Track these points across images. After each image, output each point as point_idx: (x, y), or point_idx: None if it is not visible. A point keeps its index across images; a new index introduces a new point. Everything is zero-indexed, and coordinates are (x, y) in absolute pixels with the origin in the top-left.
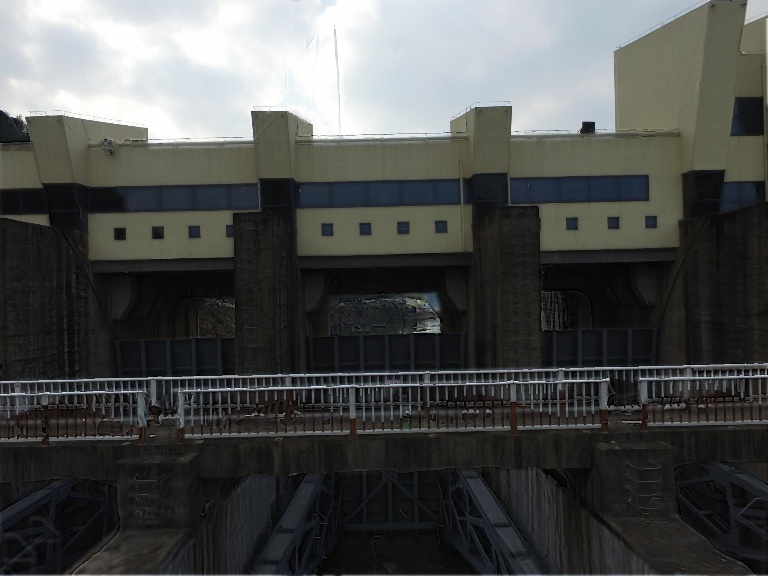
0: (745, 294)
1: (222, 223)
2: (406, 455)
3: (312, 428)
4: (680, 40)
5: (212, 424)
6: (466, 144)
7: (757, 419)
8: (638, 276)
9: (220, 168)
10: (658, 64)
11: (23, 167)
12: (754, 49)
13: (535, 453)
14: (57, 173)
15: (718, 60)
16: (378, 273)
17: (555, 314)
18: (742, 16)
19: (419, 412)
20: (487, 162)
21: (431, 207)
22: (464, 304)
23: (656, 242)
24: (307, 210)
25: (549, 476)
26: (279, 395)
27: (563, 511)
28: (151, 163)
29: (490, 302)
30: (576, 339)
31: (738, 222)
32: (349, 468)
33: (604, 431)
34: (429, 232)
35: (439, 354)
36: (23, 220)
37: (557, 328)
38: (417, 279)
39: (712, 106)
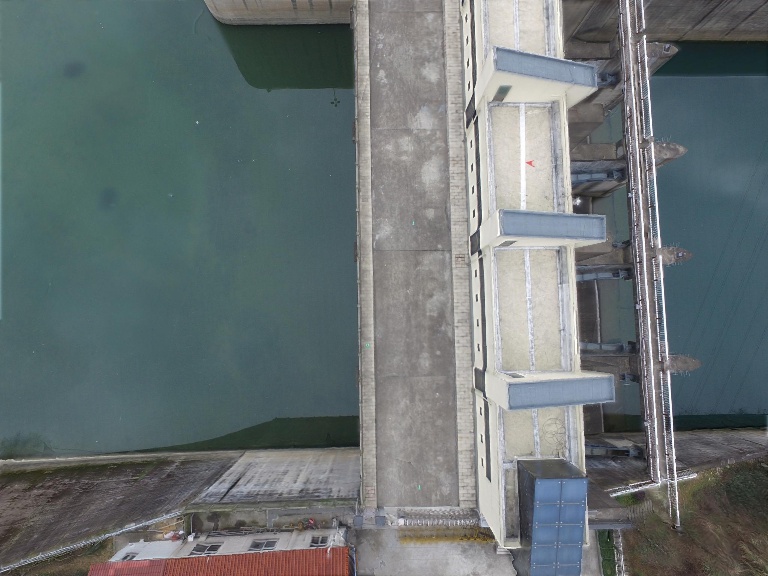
0: None
1: None
2: None
3: None
4: None
5: None
6: None
7: None
8: None
9: None
10: None
11: None
12: None
13: None
14: None
15: None
16: None
17: None
18: None
19: None
20: None
21: None
22: None
23: None
24: None
25: (600, 60)
26: None
27: None
28: None
29: None
30: None
31: None
32: None
33: None
34: None
35: None
36: None
37: None
38: None
39: None
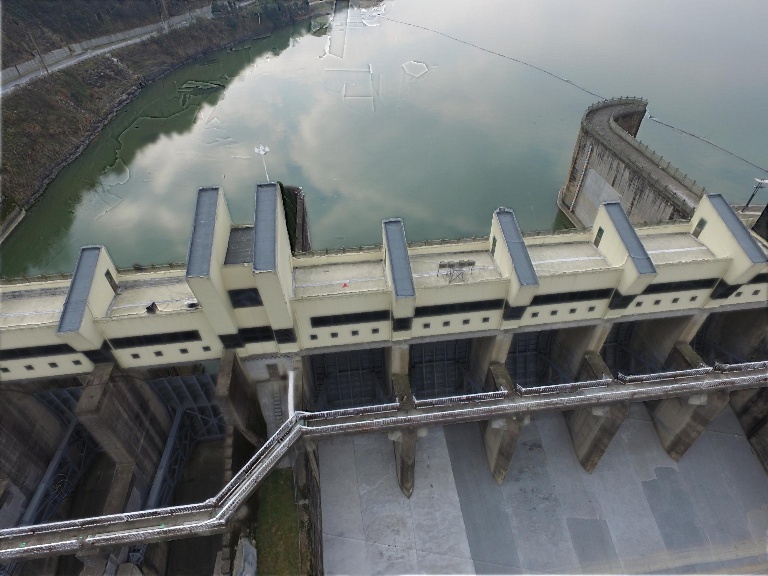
0: None
1: None
2: None
3: None
4: None
5: None
6: None
7: None
8: None
9: None
10: None
11: None
12: None
13: None
14: None
15: None
16: None
17: None
18: (212, 283)
19: None
20: None
21: (65, 355)
22: None
23: (212, 357)
24: None
25: None
26: None
27: None
28: None
29: None
30: None
31: None
32: None
33: (80, 548)
34: (71, 365)
35: None
36: None
37: None
38: None
39: (215, 314)
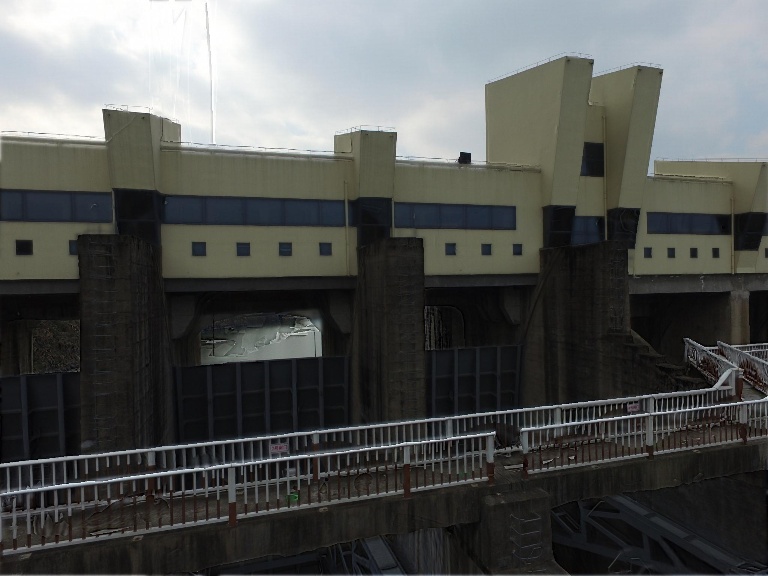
0: (592, 320)
1: (63, 238)
2: (294, 536)
3: (181, 520)
4: (542, 86)
5: (44, 532)
6: (351, 165)
7: (614, 457)
8: (506, 297)
9: (61, 171)
10: (523, 104)
11: None
12: (597, 101)
13: (427, 515)
14: None
15: (572, 109)
16: (257, 292)
17: (431, 325)
18: (590, 73)
19: (309, 486)
20: (372, 186)
21: (315, 228)
22: (348, 326)
23: (521, 268)
24: (174, 226)
25: None
26: (138, 485)
27: (450, 557)
28: None
29: (375, 331)
30: (453, 358)
31: (587, 256)
32: (227, 560)
33: (491, 484)
34: (313, 254)
35: (322, 379)
36: None
37: (433, 338)
38: (299, 298)
39: (567, 149)
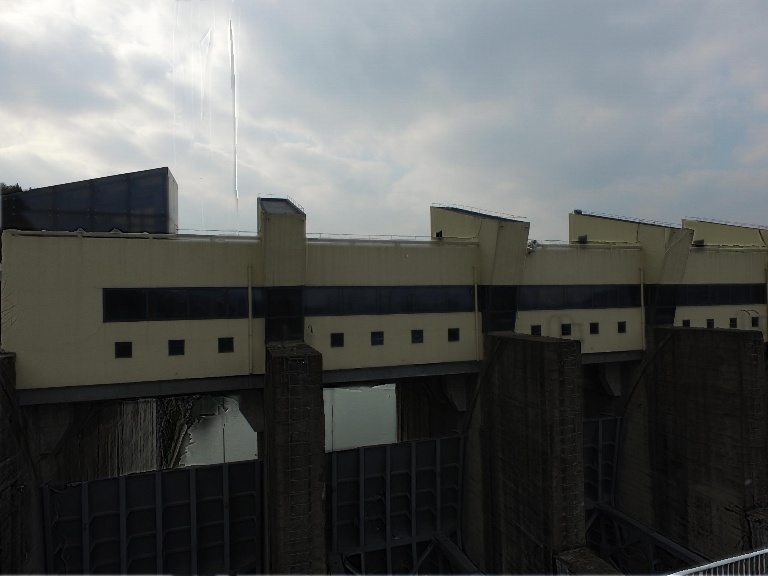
0: None
1: (614, 320)
2: None
3: None
4: None
5: None
6: None
7: None
8: None
9: (612, 270)
10: None
11: (449, 263)
12: None
13: None
14: (508, 276)
15: None
16: None
17: None
18: None
19: None
20: None
21: (749, 306)
22: None
23: None
24: None
25: None
26: None
27: None
28: (559, 263)
29: None
30: None
31: None
32: None
33: None
34: (748, 326)
35: None
36: (450, 318)
37: None
38: None
39: None
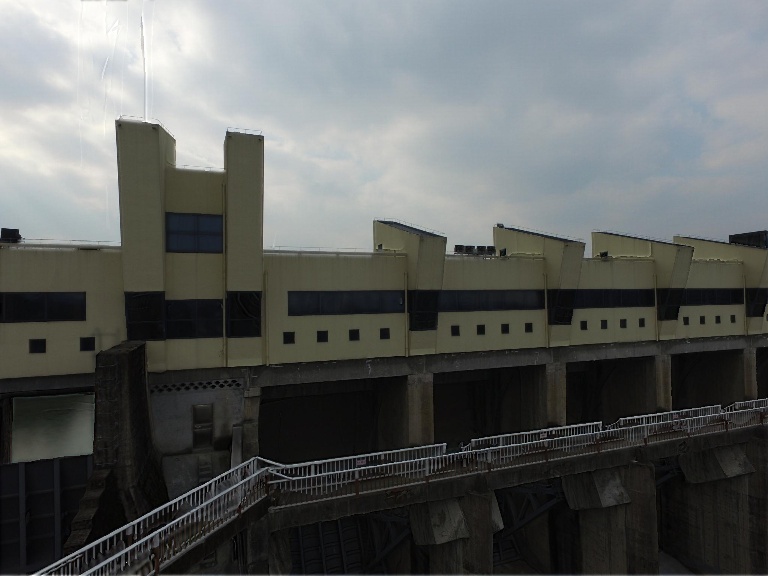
0: None
1: None
2: None
3: None
4: None
5: None
6: None
7: None
8: None
9: None
10: None
11: None
12: None
13: None
14: None
15: (137, 181)
16: None
17: None
18: (157, 140)
19: None
20: None
21: None
22: None
23: (93, 366)
24: None
25: None
26: None
27: None
28: None
29: None
30: (17, 474)
31: None
32: None
33: None
34: None
35: None
36: None
37: None
38: None
39: (138, 227)
